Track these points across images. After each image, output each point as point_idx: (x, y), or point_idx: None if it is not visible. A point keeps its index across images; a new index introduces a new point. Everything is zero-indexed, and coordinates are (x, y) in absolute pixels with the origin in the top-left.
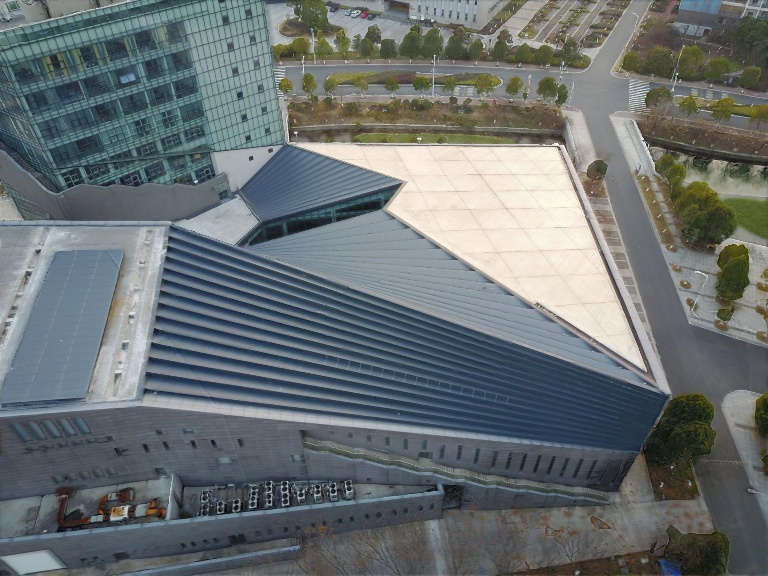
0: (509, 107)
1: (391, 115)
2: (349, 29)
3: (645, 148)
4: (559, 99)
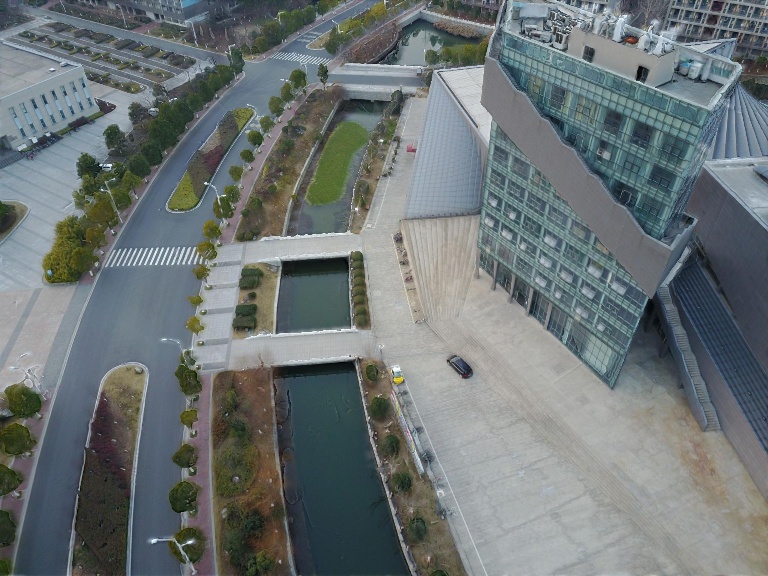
0: (302, 109)
1: (288, 172)
2: (6, 200)
3: (390, 66)
4: (324, 76)
